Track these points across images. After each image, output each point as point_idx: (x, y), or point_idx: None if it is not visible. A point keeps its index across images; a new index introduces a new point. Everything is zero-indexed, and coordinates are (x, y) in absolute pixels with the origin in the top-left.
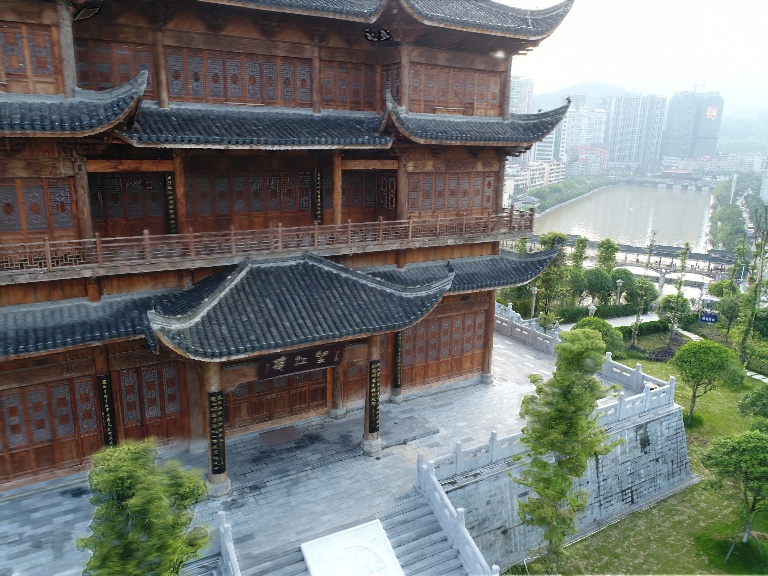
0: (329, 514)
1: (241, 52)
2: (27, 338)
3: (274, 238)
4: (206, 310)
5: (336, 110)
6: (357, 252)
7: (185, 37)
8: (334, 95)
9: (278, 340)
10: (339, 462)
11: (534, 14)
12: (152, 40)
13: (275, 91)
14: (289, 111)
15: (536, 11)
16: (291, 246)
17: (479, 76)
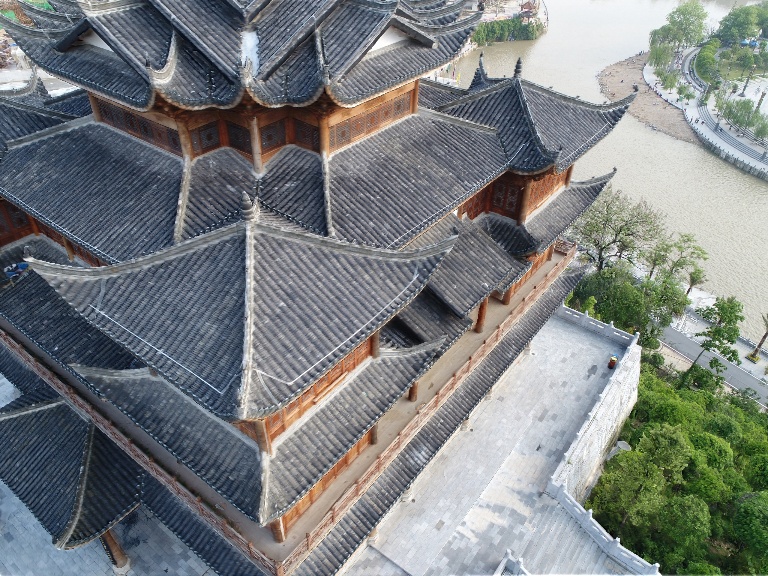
0: (34, 574)
1: None
2: (3, 359)
3: None
4: (4, 418)
5: None
6: (121, 447)
7: None
8: None
9: (0, 470)
10: (103, 552)
11: None
12: None
13: None
14: None
15: None
16: None
17: None
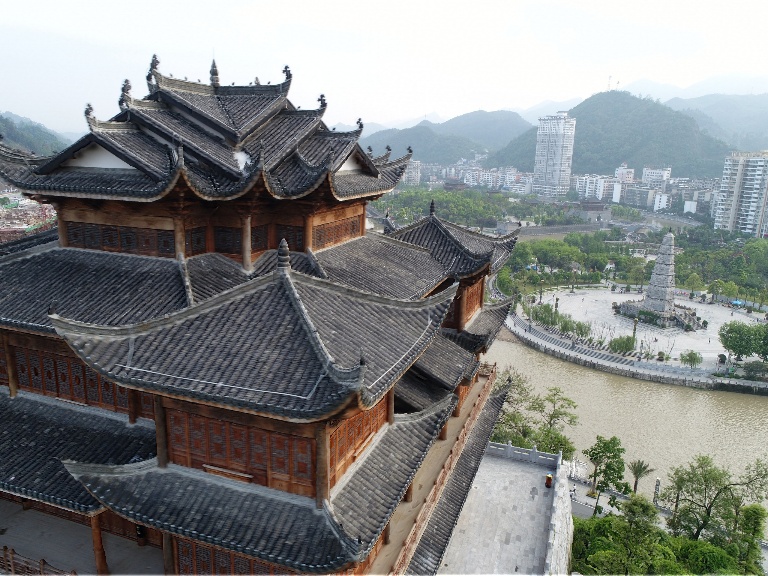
0: None
1: (63, 355)
2: None
3: (8, 561)
4: None
5: (154, 422)
6: None
7: (23, 339)
8: (153, 405)
9: None
10: None
11: (333, 371)
12: (2, 340)
13: (97, 393)
14: (108, 415)
15: (333, 368)
16: (23, 574)
17: (272, 436)
